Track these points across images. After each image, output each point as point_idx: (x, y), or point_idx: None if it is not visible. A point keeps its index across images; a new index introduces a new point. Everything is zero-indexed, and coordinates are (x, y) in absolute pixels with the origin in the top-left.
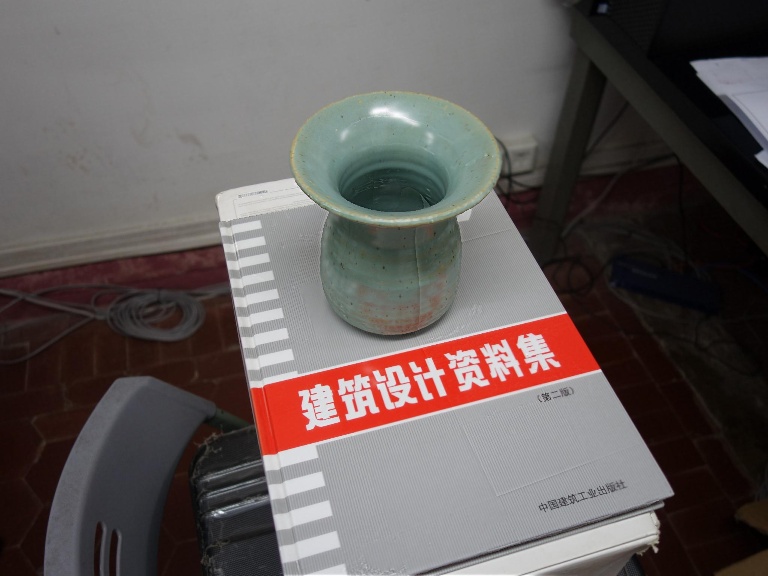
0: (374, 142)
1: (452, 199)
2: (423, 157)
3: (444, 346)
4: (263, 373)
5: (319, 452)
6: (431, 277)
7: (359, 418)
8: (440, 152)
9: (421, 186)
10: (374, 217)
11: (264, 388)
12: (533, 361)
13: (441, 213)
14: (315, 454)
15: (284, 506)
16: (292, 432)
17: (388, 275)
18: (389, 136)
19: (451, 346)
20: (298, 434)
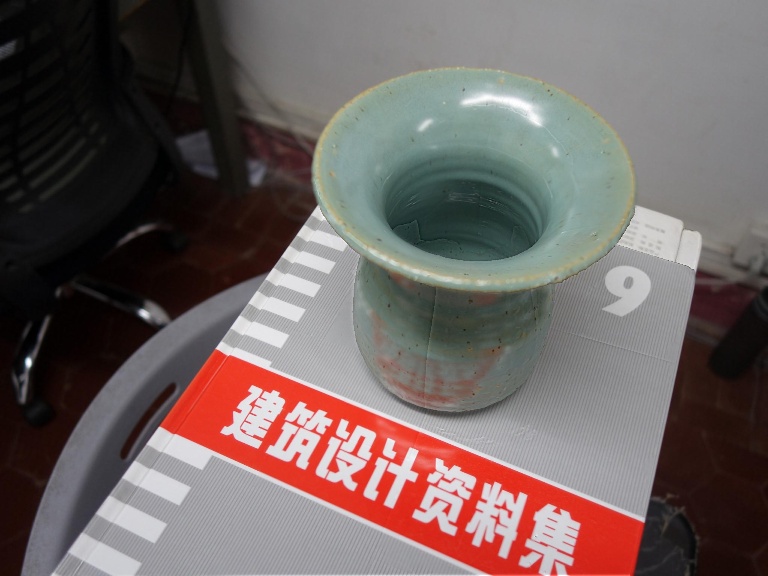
0: (491, 143)
1: (484, 266)
2: (541, 194)
3: (446, 448)
4: (240, 341)
5: (208, 465)
6: (448, 354)
7: (279, 460)
8: (559, 198)
9: (532, 233)
10: (349, 229)
11: (228, 357)
12: (536, 550)
13: (436, 274)
14: (203, 464)
15: (128, 494)
16: (206, 423)
17: (391, 318)
18: (514, 144)
19: (454, 454)
20: (209, 429)
